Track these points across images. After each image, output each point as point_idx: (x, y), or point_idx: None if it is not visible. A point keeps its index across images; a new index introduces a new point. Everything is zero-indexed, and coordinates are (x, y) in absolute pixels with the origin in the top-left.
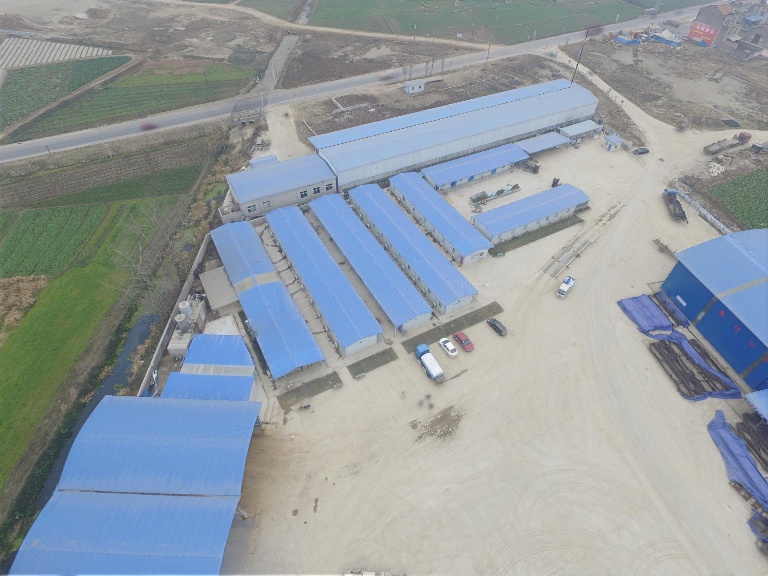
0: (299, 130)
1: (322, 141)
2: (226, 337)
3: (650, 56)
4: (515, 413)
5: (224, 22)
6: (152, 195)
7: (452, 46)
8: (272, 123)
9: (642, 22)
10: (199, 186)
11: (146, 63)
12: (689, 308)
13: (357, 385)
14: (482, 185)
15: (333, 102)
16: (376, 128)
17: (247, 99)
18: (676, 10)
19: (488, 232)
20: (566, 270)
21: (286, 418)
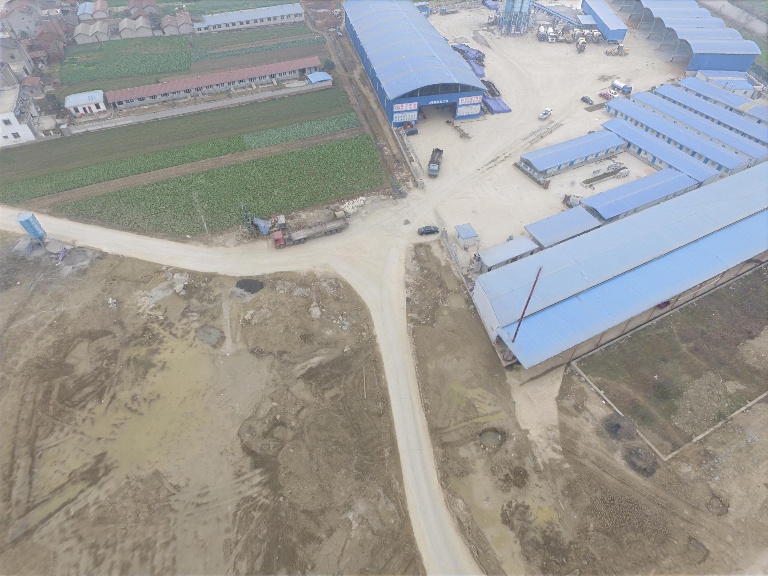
0: None
1: None
2: (737, 88)
3: None
4: None
5: None
6: None
7: None
8: None
9: None
10: None
11: None
12: None
13: None
14: None
15: None
16: None
17: None
18: None
19: None
20: None
21: (678, 79)
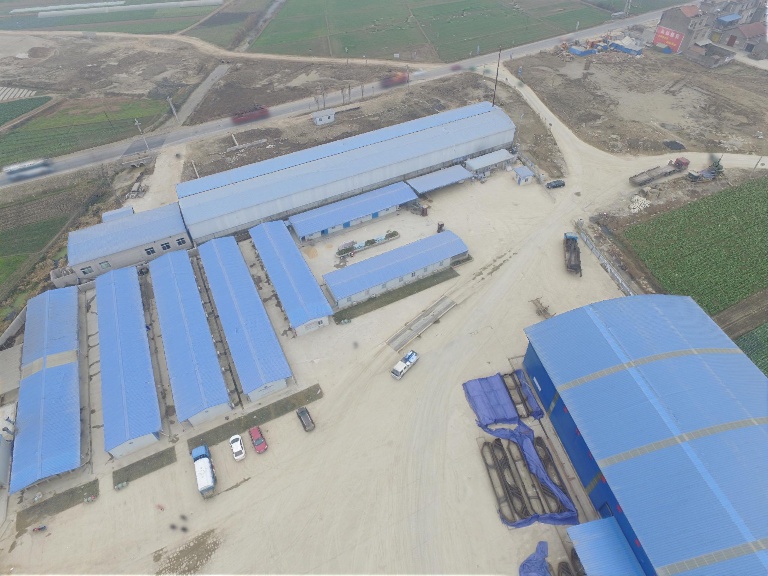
0: (184, 172)
1: (188, 188)
2: None
3: (604, 68)
4: (284, 541)
5: (160, 54)
6: (4, 253)
7: (385, 68)
8: (160, 165)
9: (606, 28)
10: (55, 242)
11: (65, 103)
12: (544, 394)
13: (114, 498)
14: (358, 232)
15: (232, 139)
16: (253, 170)
17: (145, 139)
18: (650, 12)
19: (333, 295)
20: (416, 341)
21: (15, 543)
